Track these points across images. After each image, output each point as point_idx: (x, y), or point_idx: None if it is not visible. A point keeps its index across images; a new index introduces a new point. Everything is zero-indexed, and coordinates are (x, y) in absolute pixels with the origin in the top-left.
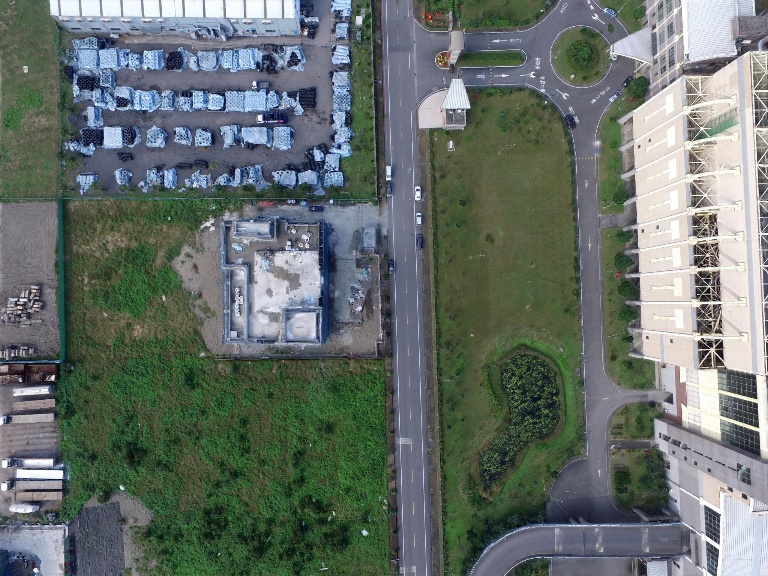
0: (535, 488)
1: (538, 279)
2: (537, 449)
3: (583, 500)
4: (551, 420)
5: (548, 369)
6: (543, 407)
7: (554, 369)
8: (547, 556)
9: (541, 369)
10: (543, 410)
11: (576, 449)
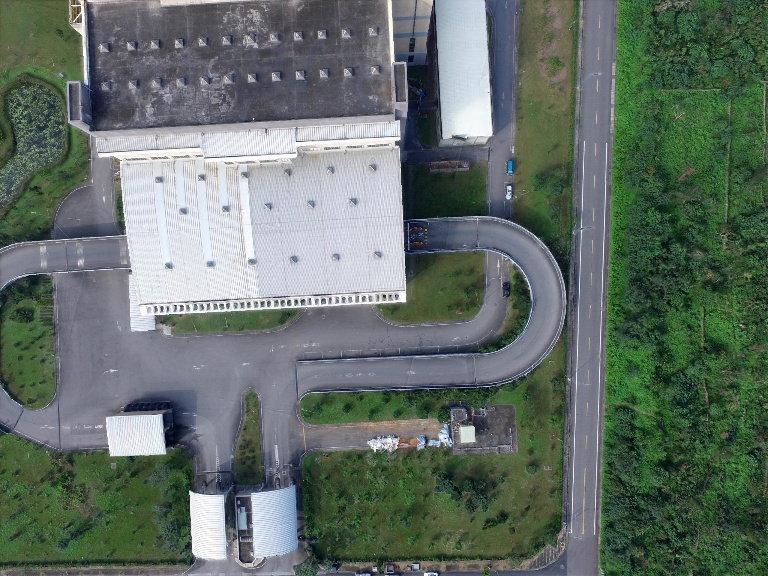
0: (39, 216)
1: (42, 7)
2: (40, 176)
3: (88, 227)
4: (57, 149)
5: (54, 98)
6: (49, 136)
7: (59, 97)
8: (32, 273)
9: (47, 98)
10: (49, 139)
11: (80, 176)
